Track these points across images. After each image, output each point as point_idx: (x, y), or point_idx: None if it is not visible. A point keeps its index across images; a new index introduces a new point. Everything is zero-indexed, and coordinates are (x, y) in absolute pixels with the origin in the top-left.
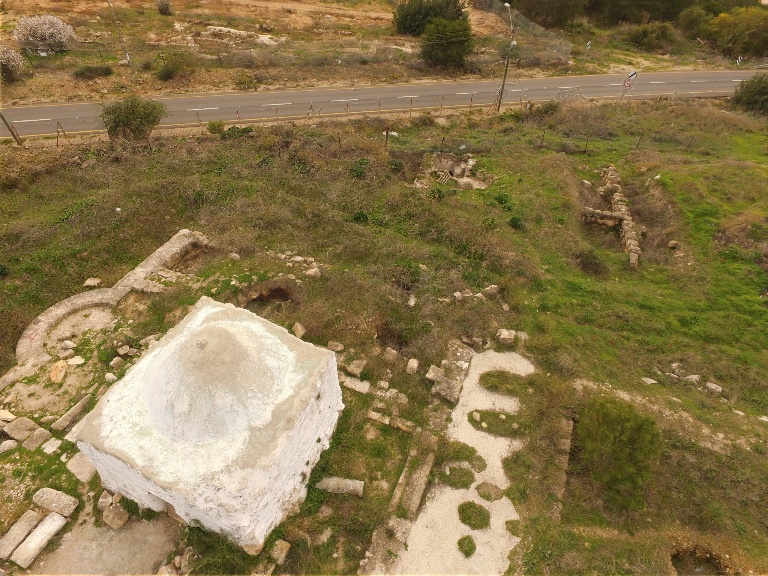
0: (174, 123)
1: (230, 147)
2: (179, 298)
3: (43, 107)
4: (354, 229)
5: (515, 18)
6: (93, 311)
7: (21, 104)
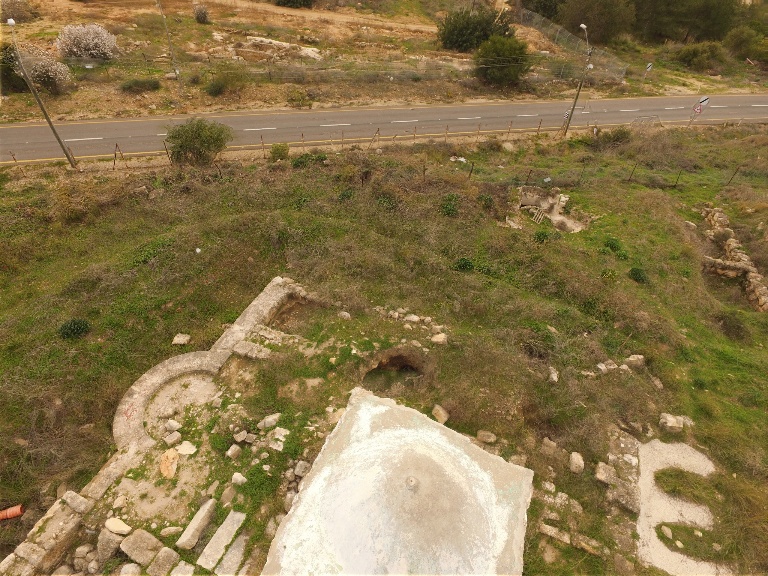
0: (233, 145)
1: (304, 177)
2: (292, 368)
3: (92, 124)
4: (462, 279)
5: (592, 40)
6: (192, 380)
7: (68, 120)
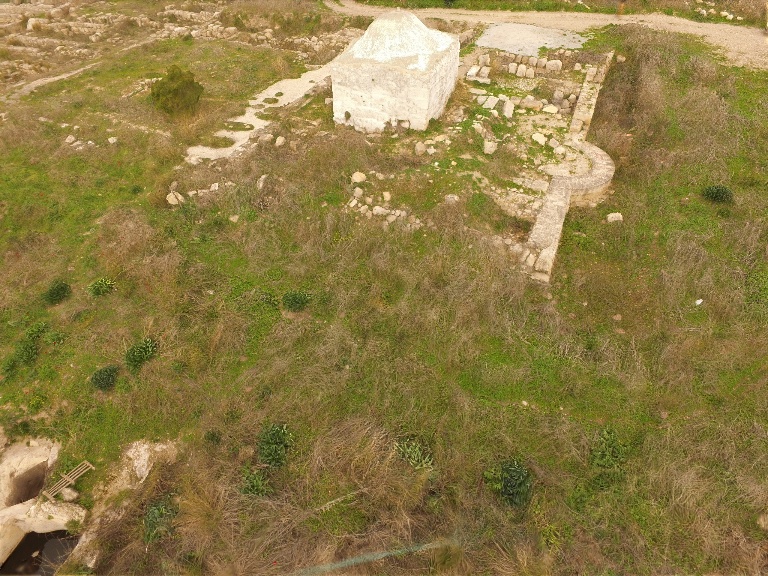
0: None
1: None
2: None
3: None
4: None
5: None
6: None
7: None
